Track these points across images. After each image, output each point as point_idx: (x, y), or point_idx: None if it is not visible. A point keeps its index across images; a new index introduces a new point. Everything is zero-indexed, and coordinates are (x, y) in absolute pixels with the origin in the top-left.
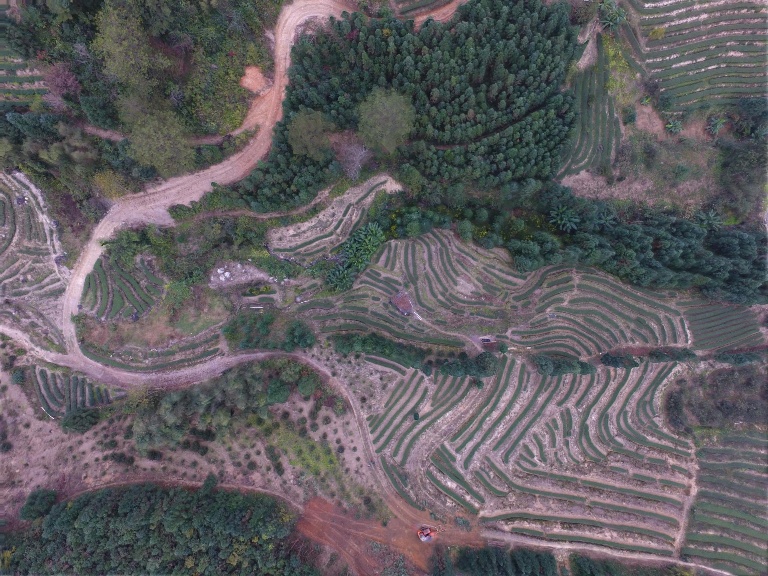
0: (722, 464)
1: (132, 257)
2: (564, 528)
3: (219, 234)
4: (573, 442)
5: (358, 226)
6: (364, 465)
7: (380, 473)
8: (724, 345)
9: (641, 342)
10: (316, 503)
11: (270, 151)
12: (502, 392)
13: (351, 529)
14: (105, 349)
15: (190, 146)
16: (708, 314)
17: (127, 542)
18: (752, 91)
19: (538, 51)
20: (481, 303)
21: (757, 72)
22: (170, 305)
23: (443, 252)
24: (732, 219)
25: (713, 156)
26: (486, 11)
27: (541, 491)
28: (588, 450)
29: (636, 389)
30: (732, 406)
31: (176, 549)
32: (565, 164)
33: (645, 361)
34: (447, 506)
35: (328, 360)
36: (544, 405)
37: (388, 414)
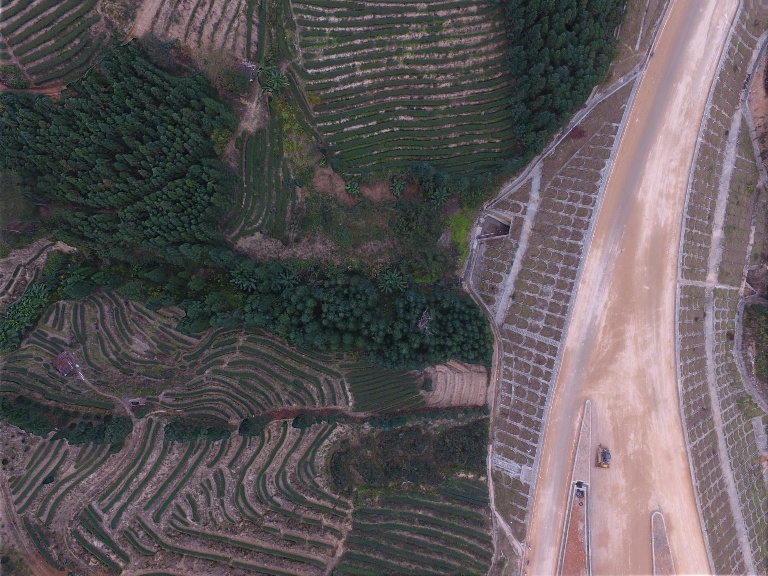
0: (375, 525)
1: None
2: None
3: None
4: (228, 502)
5: None
6: (6, 525)
7: (22, 533)
8: (386, 407)
9: (299, 404)
10: None
11: None
12: (147, 455)
13: None
14: None
15: None
16: (367, 377)
17: None
18: (428, 154)
19: (164, 124)
20: (153, 362)
21: (430, 136)
22: None
23: (119, 311)
24: (428, 277)
25: (395, 217)
26: (94, 88)
27: (188, 551)
28: (245, 509)
29: (294, 450)
30: (395, 467)
31: None
32: (238, 226)
33: None
34: (90, 565)
35: None
36: (193, 467)
37: (31, 476)
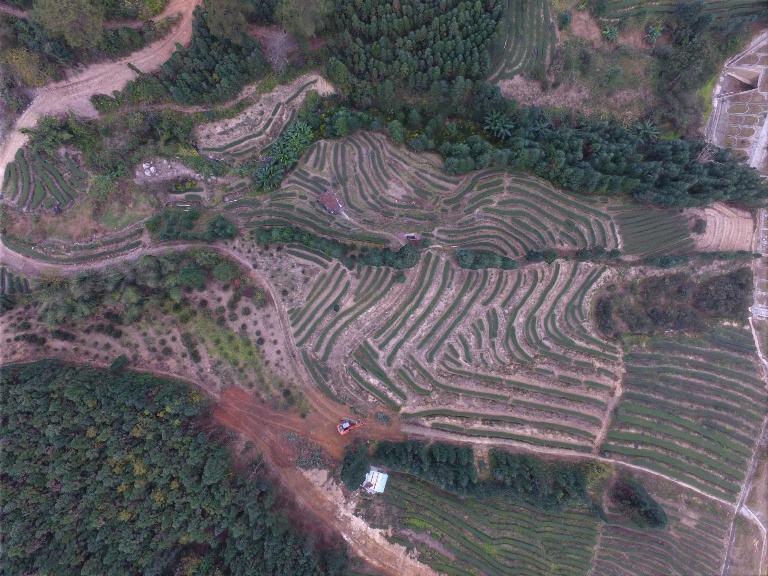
0: (649, 368)
1: (56, 150)
2: (484, 424)
3: (142, 124)
4: (499, 344)
5: (289, 127)
6: (285, 358)
7: (301, 367)
8: (654, 251)
9: (570, 245)
10: (233, 392)
11: (192, 39)
12: (426, 289)
13: (268, 420)
14: (27, 241)
15: (109, 29)
16: (638, 218)
17: (27, 408)
18: None
19: None
20: (412, 207)
21: None
22: (93, 198)
23: (375, 155)
24: (671, 133)
25: (650, 65)
26: None
27: (465, 390)
28: (515, 352)
29: (564, 292)
30: (662, 313)
31: (76, 417)
32: (499, 68)
33: (574, 264)
34: (368, 402)
35: (250, 252)
36: (469, 304)
37: (310, 308)
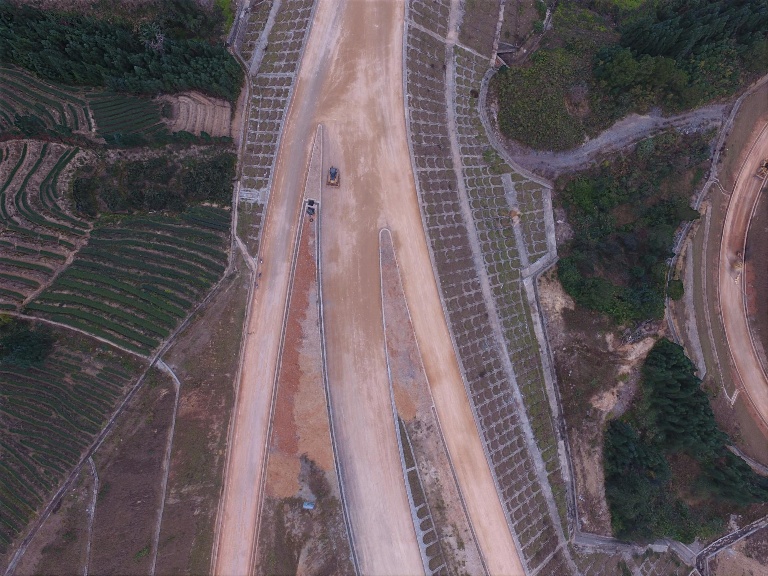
0: (111, 241)
1: None
2: None
3: None
4: None
5: None
6: None
7: None
8: None
9: None
10: None
11: None
12: None
13: None
14: None
15: None
16: (109, 103)
17: None
18: None
19: None
20: None
21: None
22: None
23: None
24: None
25: None
26: None
27: None
28: None
29: (34, 171)
30: (139, 193)
31: None
32: None
33: (43, 144)
34: None
35: None
36: None
37: None
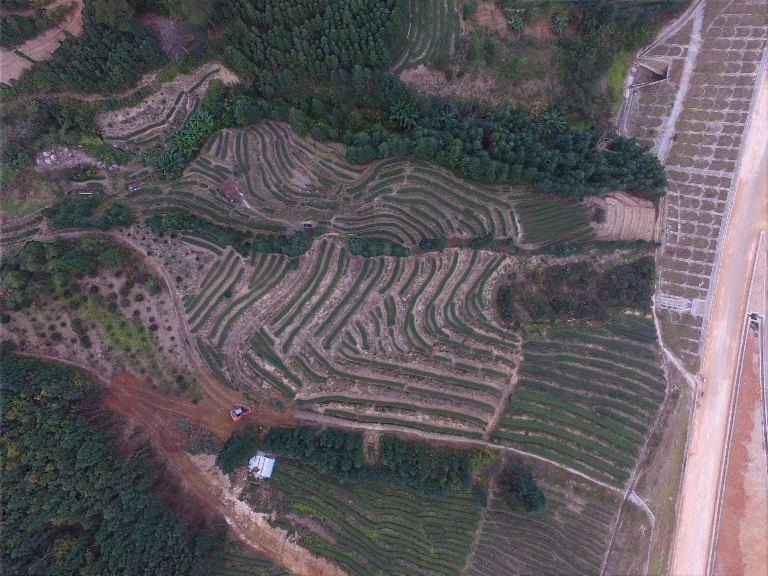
0: (547, 356)
1: None
2: (377, 410)
3: (38, 112)
4: (398, 331)
5: None
6: (179, 345)
7: (195, 353)
8: (555, 239)
9: (469, 233)
10: (123, 377)
11: None
12: (321, 276)
13: (160, 405)
14: None
15: None
16: (538, 207)
17: None
18: None
19: None
20: (315, 195)
21: None
22: None
23: (279, 144)
24: (582, 124)
25: (556, 55)
26: None
27: (361, 377)
28: (414, 340)
29: (463, 280)
30: (563, 301)
31: None
32: (402, 57)
33: (473, 252)
34: (263, 388)
35: (144, 239)
36: (366, 292)
37: (204, 295)
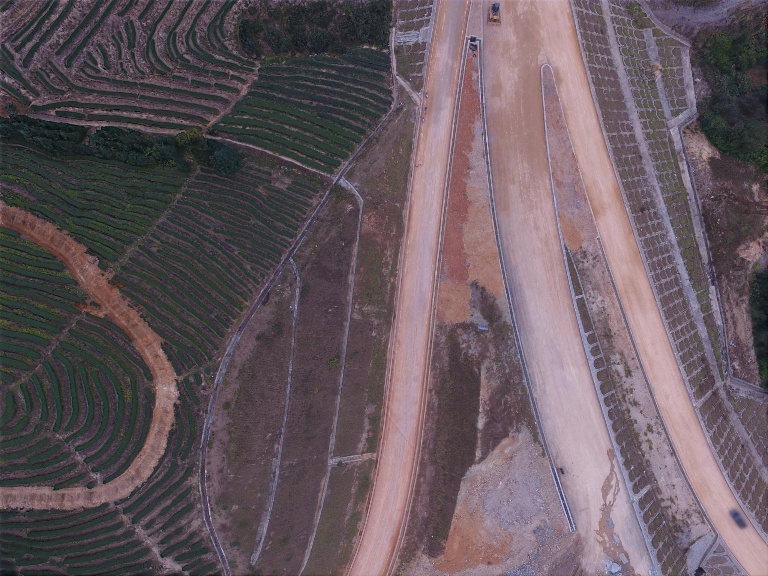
0: (280, 76)
1: None
2: (104, 110)
3: None
4: (139, 55)
5: None
6: None
7: None
8: None
9: None
10: None
11: None
12: None
13: None
14: None
15: None
16: None
17: None
18: None
19: None
20: None
21: None
22: None
23: None
24: None
25: None
26: None
27: (98, 90)
28: (156, 65)
29: (203, 11)
30: (301, 34)
31: None
32: None
33: None
34: None
35: None
36: (104, 13)
37: None
